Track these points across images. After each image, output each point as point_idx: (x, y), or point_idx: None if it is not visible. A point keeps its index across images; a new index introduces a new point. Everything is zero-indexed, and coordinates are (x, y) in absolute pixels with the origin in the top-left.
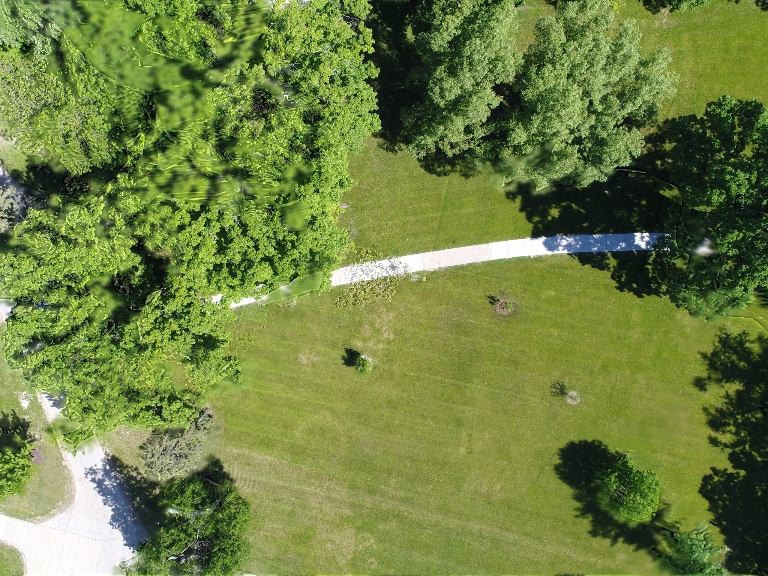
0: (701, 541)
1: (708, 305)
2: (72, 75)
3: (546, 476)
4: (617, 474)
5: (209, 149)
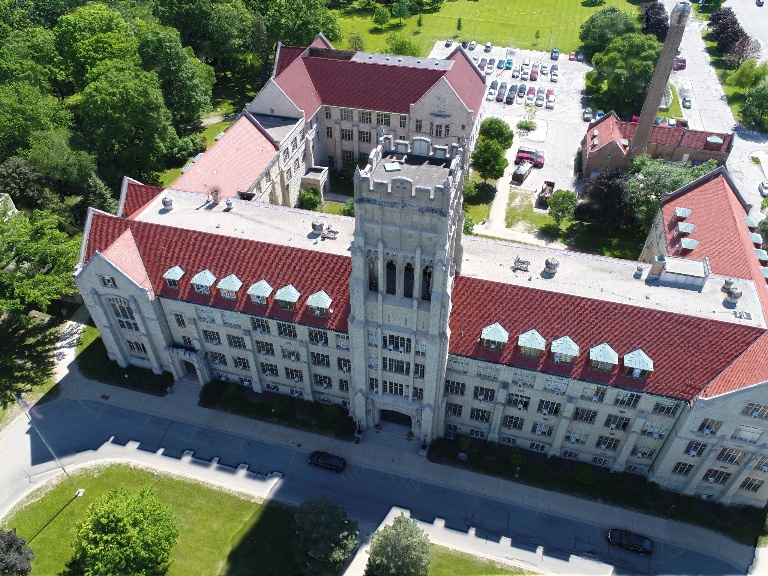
0: (395, 4)
1: (327, 1)
2: (226, 1)
3: (381, 36)
4: (376, 16)
5: (255, 10)
